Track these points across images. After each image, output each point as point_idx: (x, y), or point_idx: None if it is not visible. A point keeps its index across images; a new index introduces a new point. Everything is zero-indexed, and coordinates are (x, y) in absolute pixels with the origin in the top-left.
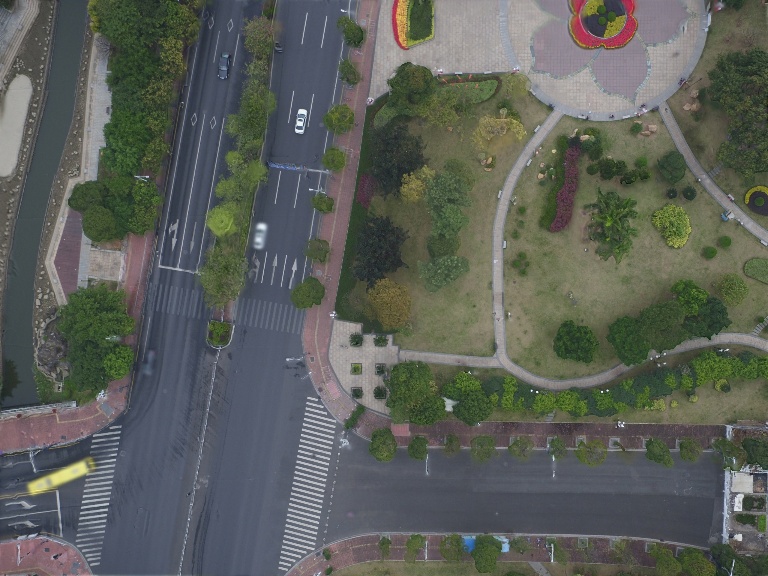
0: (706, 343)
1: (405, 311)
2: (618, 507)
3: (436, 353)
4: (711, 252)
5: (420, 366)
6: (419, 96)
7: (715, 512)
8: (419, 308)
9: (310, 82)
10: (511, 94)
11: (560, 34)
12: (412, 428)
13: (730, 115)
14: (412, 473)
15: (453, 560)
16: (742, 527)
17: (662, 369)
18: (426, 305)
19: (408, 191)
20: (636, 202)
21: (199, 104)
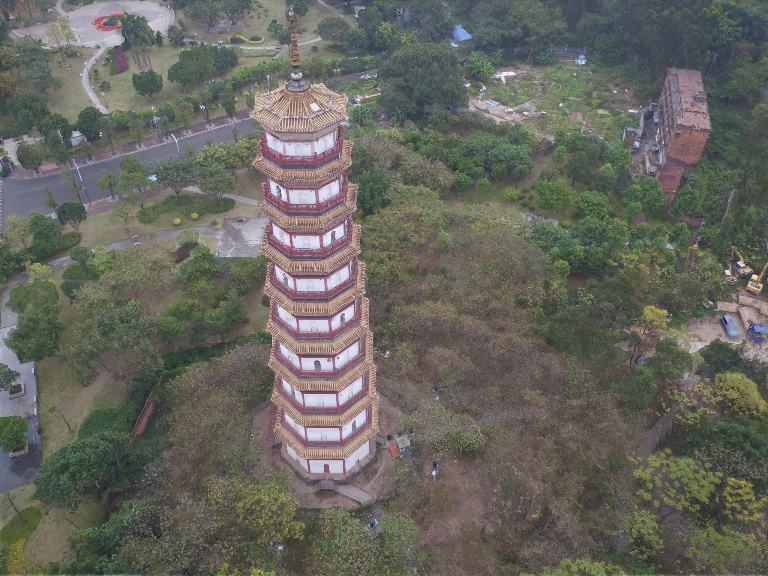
0: None
1: None
2: None
3: None
4: None
5: None
6: (1, 33)
7: None
8: None
9: None
10: (72, 49)
11: (93, 31)
12: (58, 164)
13: (184, 0)
14: None
15: None
16: None
17: None
18: None
19: (4, 53)
20: None
21: None
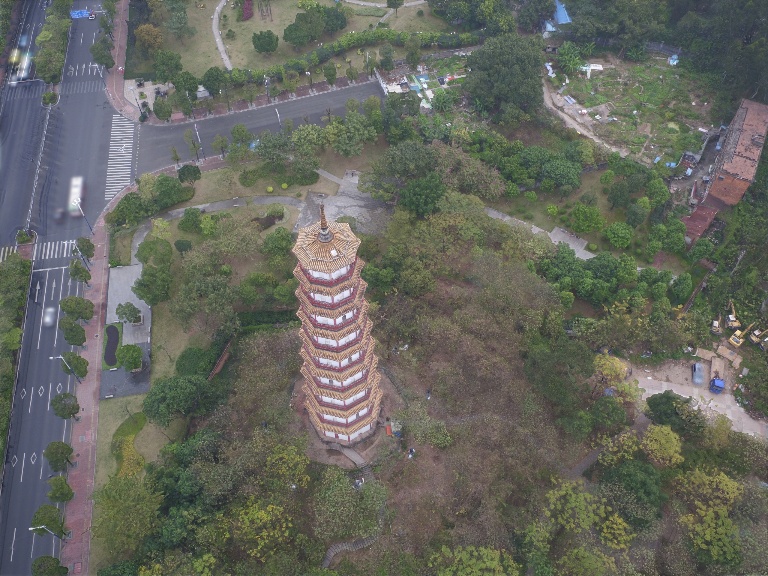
0: None
1: (159, 39)
2: None
3: None
4: (332, 7)
5: None
6: None
7: None
8: None
9: (95, 1)
10: None
11: None
12: None
13: None
14: None
15: (228, 166)
16: None
17: None
18: None
19: None
20: None
21: (31, 21)
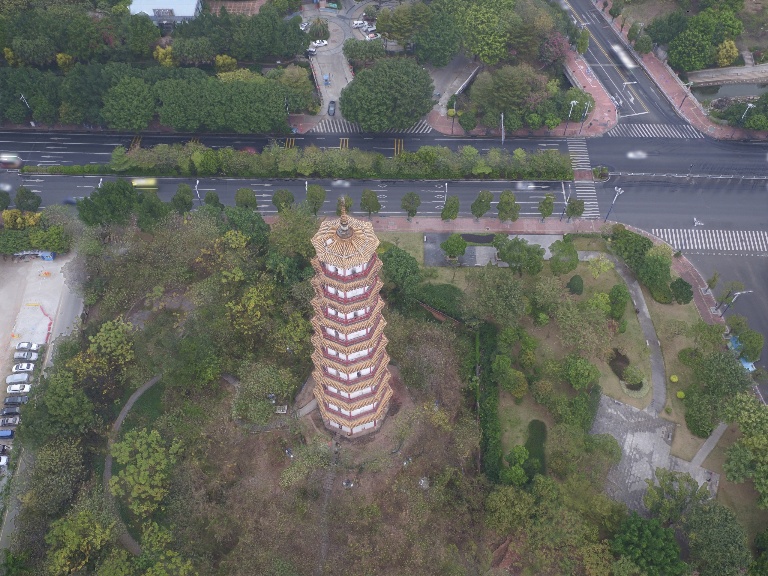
0: None
1: None
2: None
3: None
4: None
5: None
6: None
7: None
8: None
9: None
10: None
11: None
12: None
13: None
14: (764, 303)
15: None
16: None
17: None
18: None
19: None
20: None
21: None
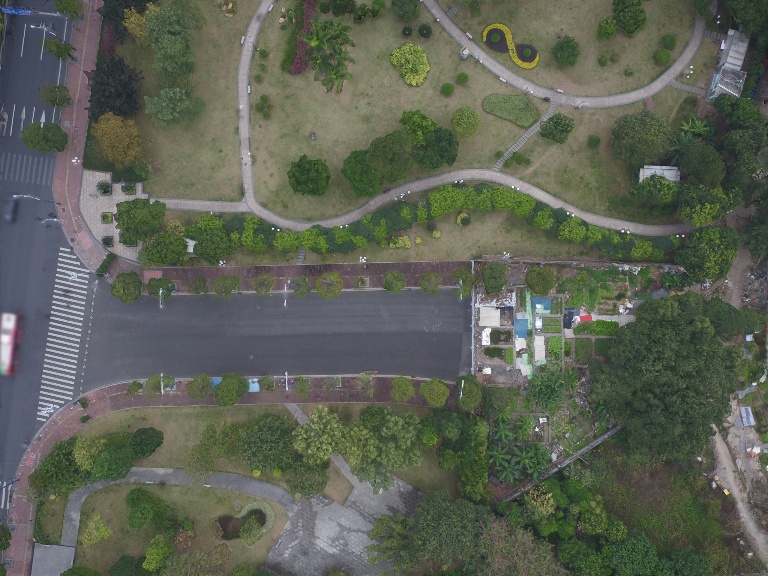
0: (449, 180)
1: (133, 146)
2: (369, 346)
3: (185, 200)
4: (447, 88)
5: (155, 203)
6: None
7: (464, 347)
8: (166, 155)
9: None
10: None
11: None
12: (165, 275)
13: None
14: (166, 320)
15: (209, 405)
16: (491, 361)
17: (400, 203)
18: (172, 151)
19: (130, 26)
20: (349, 27)
21: None
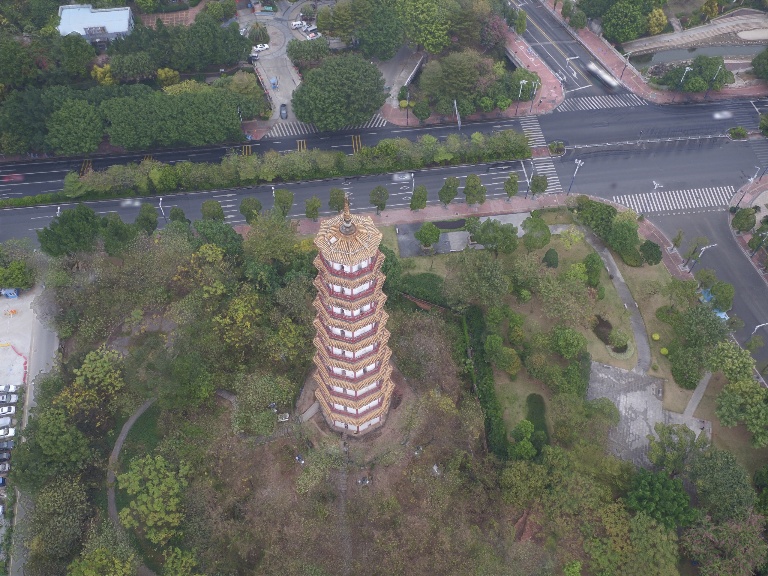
0: None
1: None
2: None
3: None
4: None
5: None
6: None
7: None
8: None
9: None
10: None
11: None
12: None
13: None
14: (726, 255)
15: None
16: None
17: None
18: None
19: None
20: None
21: None
